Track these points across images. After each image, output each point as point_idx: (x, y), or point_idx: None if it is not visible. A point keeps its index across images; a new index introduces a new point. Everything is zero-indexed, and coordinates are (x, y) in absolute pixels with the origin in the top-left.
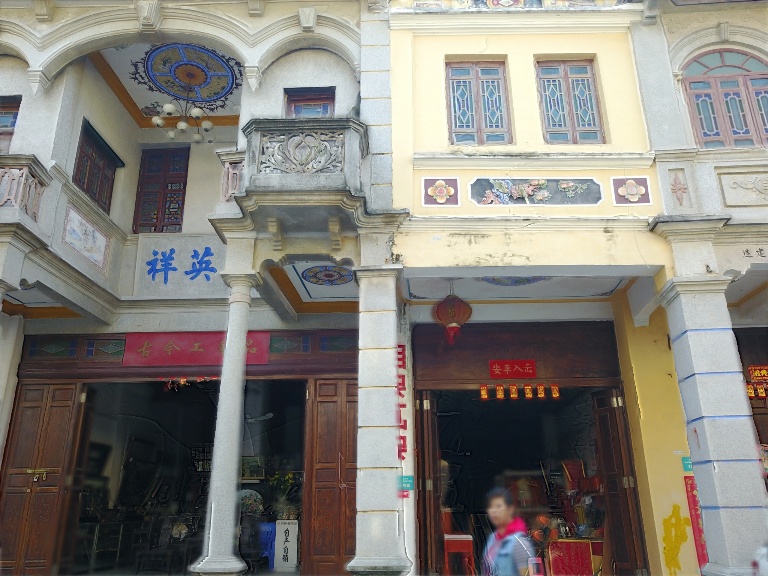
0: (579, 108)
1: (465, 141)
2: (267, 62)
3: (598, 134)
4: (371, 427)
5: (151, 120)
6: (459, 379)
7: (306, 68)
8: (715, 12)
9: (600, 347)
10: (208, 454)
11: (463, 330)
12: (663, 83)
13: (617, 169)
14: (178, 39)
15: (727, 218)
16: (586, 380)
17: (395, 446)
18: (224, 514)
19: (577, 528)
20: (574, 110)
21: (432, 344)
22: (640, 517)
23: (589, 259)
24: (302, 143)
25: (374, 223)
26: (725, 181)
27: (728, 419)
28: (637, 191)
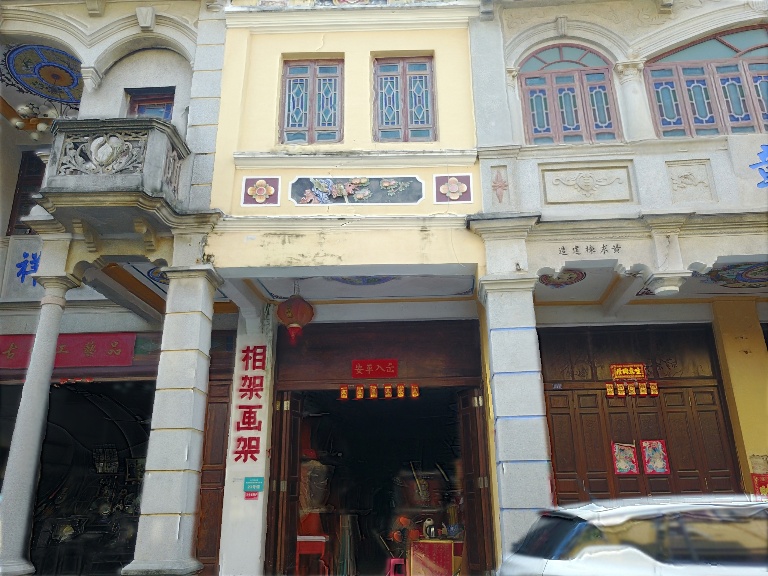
0: (414, 105)
1: (295, 140)
2: (107, 62)
3: (430, 131)
4: (164, 429)
5: (29, 122)
6: (320, 379)
7: (148, 68)
8: (556, 7)
9: (464, 346)
10: (108, 455)
11: (328, 330)
12: (495, 79)
13: (441, 167)
14: (21, 40)
15: (536, 215)
16: (449, 380)
17: (185, 448)
18: (10, 518)
19: (448, 529)
20: (408, 107)
21: (296, 344)
22: (491, 518)
23: (401, 258)
24: (105, 144)
25: (187, 224)
26: (548, 178)
27: (521, 419)
28: (458, 189)
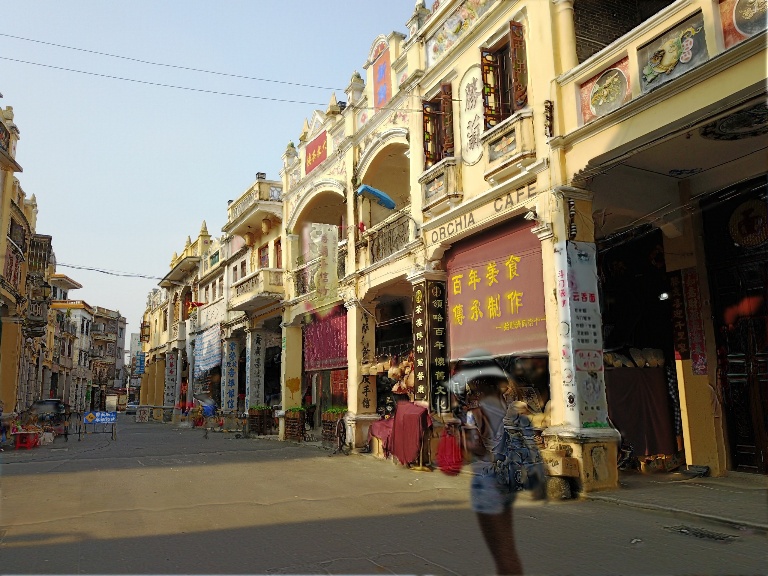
0: None
1: None
2: None
3: None
4: None
5: None
6: None
7: None
8: None
9: None
10: None
11: None
12: None
13: None
14: None
15: None
16: None
17: None
18: None
19: None
20: None
21: None
22: None
23: None
24: None
25: None
26: None
27: None
28: None
